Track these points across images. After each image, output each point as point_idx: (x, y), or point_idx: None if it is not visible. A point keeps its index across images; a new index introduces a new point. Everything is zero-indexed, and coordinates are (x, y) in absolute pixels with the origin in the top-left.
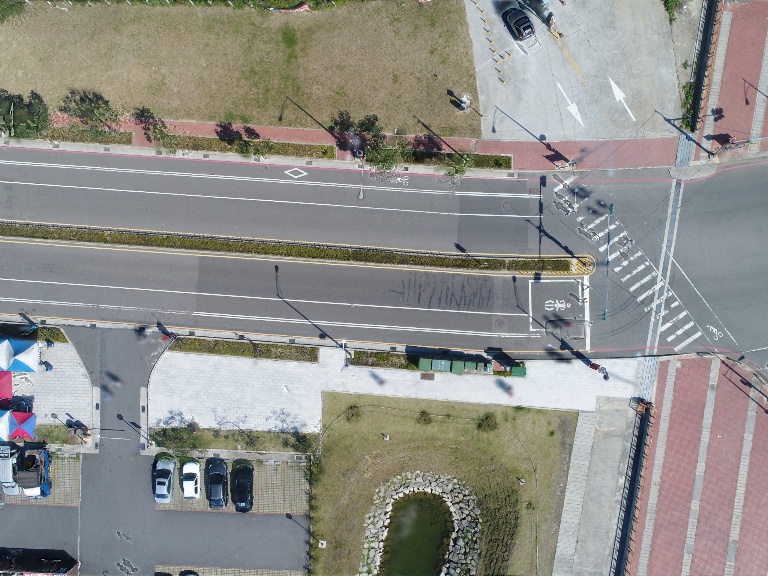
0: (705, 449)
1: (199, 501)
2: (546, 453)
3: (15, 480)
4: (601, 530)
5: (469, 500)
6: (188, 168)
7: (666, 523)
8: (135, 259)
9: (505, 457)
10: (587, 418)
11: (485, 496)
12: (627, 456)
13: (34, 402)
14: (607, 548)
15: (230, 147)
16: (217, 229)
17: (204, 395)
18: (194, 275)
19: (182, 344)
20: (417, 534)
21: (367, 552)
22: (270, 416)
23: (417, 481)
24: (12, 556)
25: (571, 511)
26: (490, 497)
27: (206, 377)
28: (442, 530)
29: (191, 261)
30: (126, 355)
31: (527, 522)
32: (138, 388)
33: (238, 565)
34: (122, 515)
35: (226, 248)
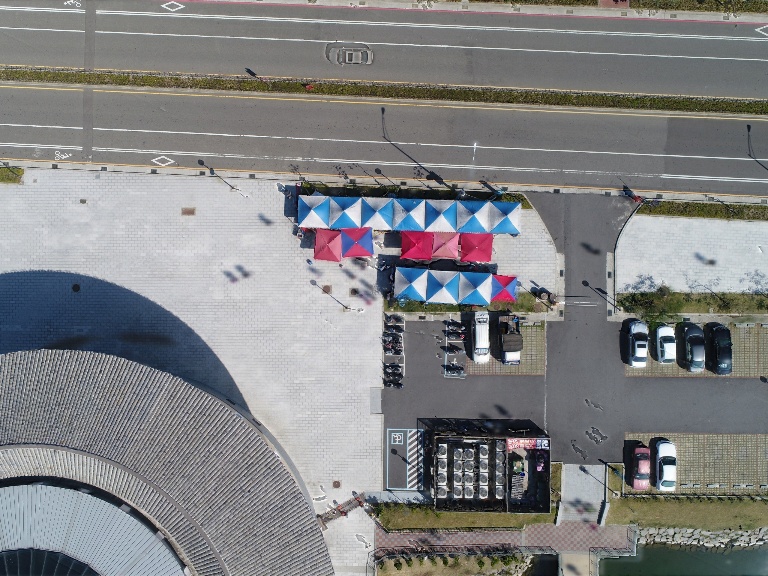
0: None
1: (669, 366)
2: None
3: (489, 347)
4: None
5: None
6: (655, 28)
7: None
8: (601, 122)
9: None
10: None
11: None
12: None
13: (498, 270)
14: None
15: (699, 6)
16: (686, 89)
17: (675, 258)
18: (662, 137)
19: (652, 207)
20: None
21: None
22: (744, 278)
23: None
24: (476, 427)
25: None
26: None
27: (677, 240)
28: None
29: (659, 122)
30: (592, 220)
31: None
32: (604, 253)
33: (711, 430)
34: (590, 383)
35: (699, 107)
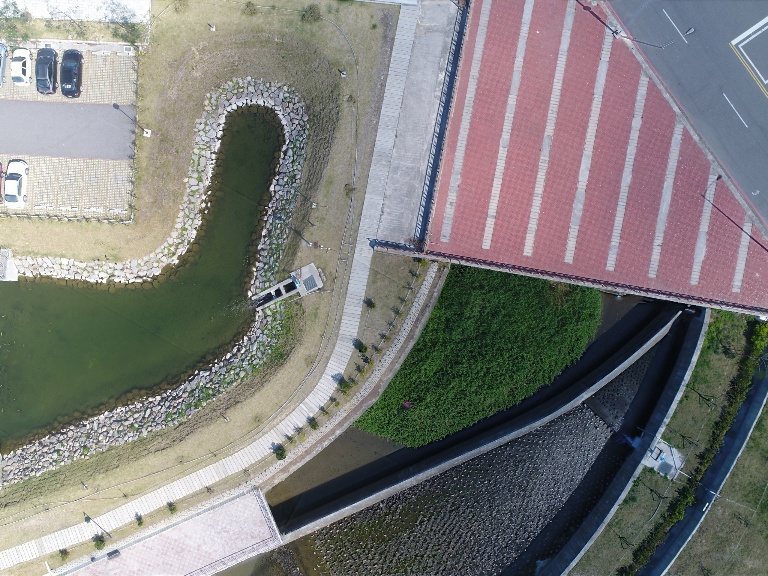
0: (524, 44)
1: (30, 91)
2: (368, 46)
3: None
4: (420, 125)
5: (298, 108)
6: None
7: (483, 117)
8: None
9: (328, 49)
10: (409, 11)
11: (312, 99)
12: (447, 51)
13: None
14: (425, 143)
15: None
16: None
17: None
18: None
19: None
20: (250, 150)
21: (197, 158)
22: (101, 6)
23: (249, 92)
24: None
25: (391, 105)
26: (316, 99)
27: None
28: (274, 146)
29: None
30: None
31: (348, 115)
32: None
33: (65, 154)
34: None
35: None
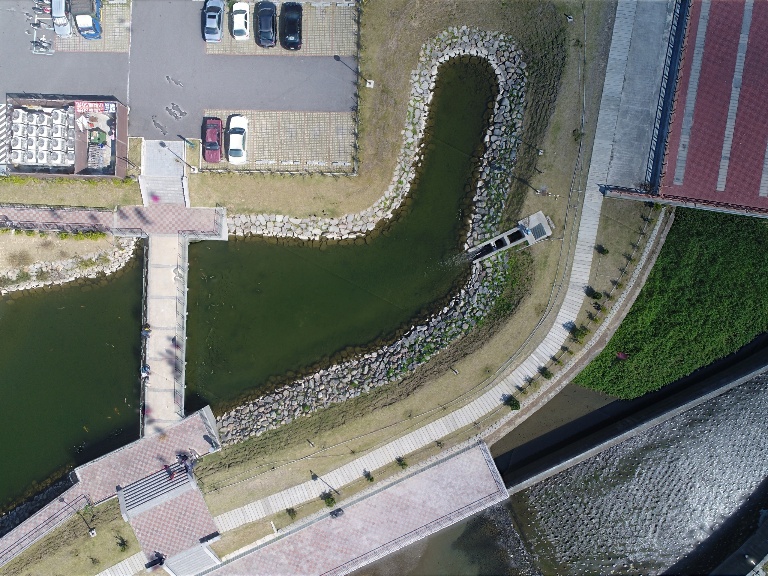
0: None
1: (248, 45)
2: None
3: (67, 16)
4: (649, 68)
5: (515, 56)
6: None
7: (714, 57)
8: None
9: None
10: None
11: (532, 46)
12: None
13: None
14: (654, 86)
15: None
16: None
17: None
18: None
19: None
20: (462, 102)
21: (413, 110)
22: None
23: (463, 42)
24: None
25: (619, 48)
26: (537, 45)
27: None
28: (487, 96)
29: None
30: None
31: (574, 60)
32: None
33: (286, 108)
34: (171, 60)
35: None
